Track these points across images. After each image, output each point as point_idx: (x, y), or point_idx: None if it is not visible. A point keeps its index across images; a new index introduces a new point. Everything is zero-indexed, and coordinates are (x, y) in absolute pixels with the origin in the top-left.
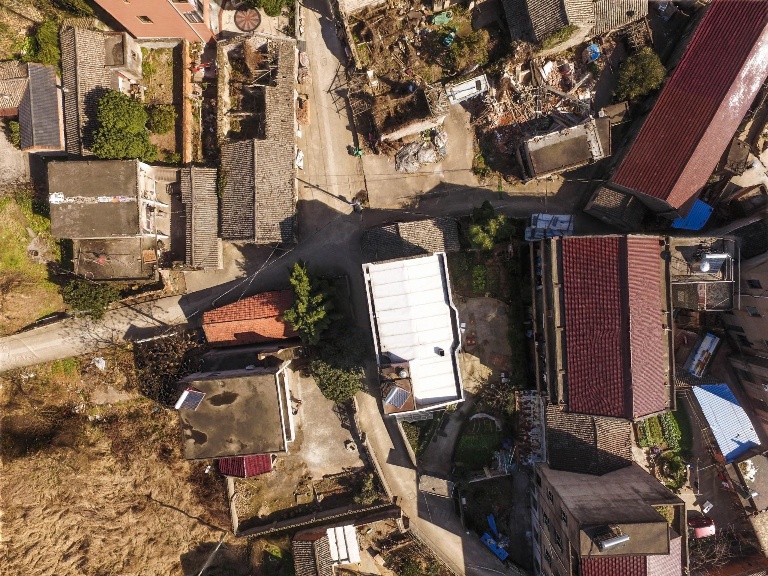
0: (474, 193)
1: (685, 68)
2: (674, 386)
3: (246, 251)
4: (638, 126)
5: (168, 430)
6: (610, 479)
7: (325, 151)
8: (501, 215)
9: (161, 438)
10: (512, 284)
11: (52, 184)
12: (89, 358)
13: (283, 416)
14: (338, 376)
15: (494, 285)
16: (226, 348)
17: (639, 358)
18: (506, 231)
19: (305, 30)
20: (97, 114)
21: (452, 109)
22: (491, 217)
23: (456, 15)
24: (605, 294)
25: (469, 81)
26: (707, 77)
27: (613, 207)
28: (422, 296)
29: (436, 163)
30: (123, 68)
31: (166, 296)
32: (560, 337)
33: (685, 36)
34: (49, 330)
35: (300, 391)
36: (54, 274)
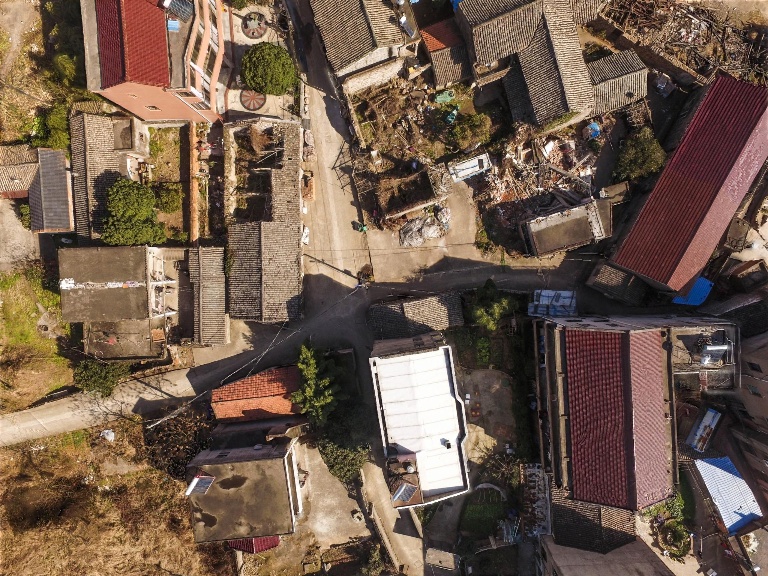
0: None
1: (684, 152)
2: (677, 460)
3: (253, 325)
4: (638, 205)
5: (177, 500)
6: (615, 558)
7: (330, 226)
8: (505, 299)
9: (170, 508)
10: (516, 359)
11: (63, 270)
12: (98, 430)
13: (291, 498)
14: (345, 455)
15: (498, 357)
16: (234, 424)
17: (642, 459)
18: (509, 307)
19: (310, 108)
20: (107, 203)
21: (455, 186)
22: (495, 300)
23: (458, 93)
24: (608, 387)
25: (472, 160)
26: (706, 162)
27: (615, 285)
28: (428, 389)
29: (440, 238)
30: (131, 151)
31: (174, 369)
32: (564, 425)
33: (684, 114)
34: (59, 403)
35: (307, 462)
36: (64, 348)
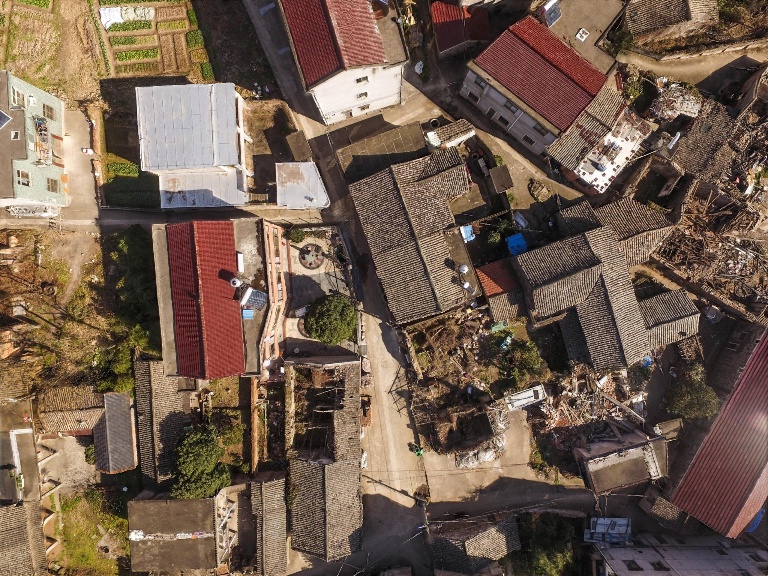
0: (532, 486)
1: (738, 400)
2: None
3: None
4: (692, 439)
5: None
6: None
7: (387, 448)
8: (568, 551)
9: None
10: None
11: (132, 522)
12: None
13: None
14: None
15: None
16: None
17: None
18: None
19: (366, 335)
20: (177, 463)
21: None
22: (557, 547)
23: (511, 320)
24: None
25: (527, 391)
26: (761, 415)
27: (670, 519)
28: None
29: (495, 460)
30: None
31: None
32: None
33: (733, 345)
34: None
35: None
36: (124, 568)
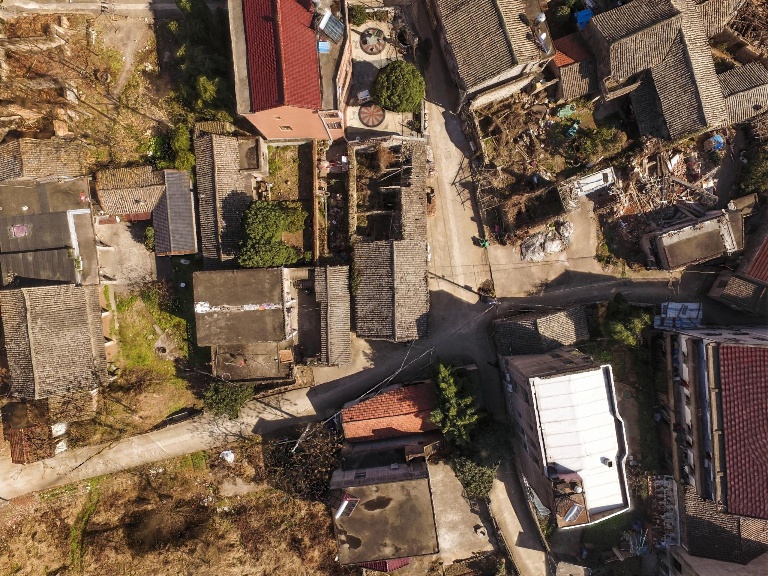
0: (598, 280)
1: None
2: None
3: (373, 342)
4: (766, 216)
5: (297, 519)
6: (757, 569)
7: (450, 242)
8: (646, 315)
9: (290, 527)
10: (643, 371)
11: (197, 294)
12: (217, 452)
13: None
14: (482, 473)
15: (620, 370)
16: (362, 443)
17: None
18: None
19: (429, 124)
20: (245, 226)
21: None
22: (633, 315)
23: (578, 107)
24: None
25: (596, 174)
26: None
27: (745, 297)
28: (588, 408)
29: (561, 252)
30: (257, 171)
31: (294, 388)
32: (717, 440)
33: None
34: (178, 426)
35: None
36: (182, 370)
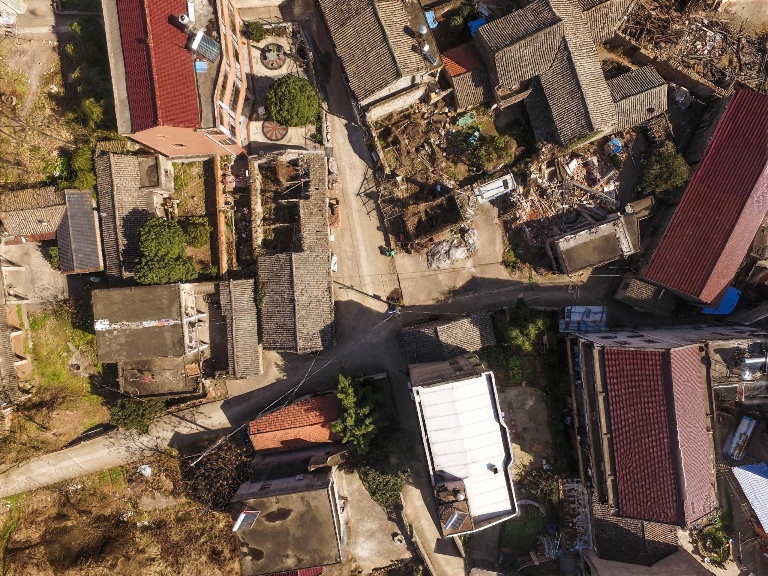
0: (506, 285)
1: (708, 165)
2: (714, 469)
3: (285, 353)
4: (664, 218)
5: (216, 532)
6: (660, 571)
7: (357, 252)
8: (539, 320)
9: (210, 540)
10: (549, 376)
11: (97, 311)
12: (135, 466)
13: (337, 527)
14: (387, 481)
15: (530, 374)
16: (272, 454)
17: (692, 477)
18: None
19: (332, 136)
20: (139, 244)
21: (480, 207)
22: (529, 320)
23: (479, 114)
24: (650, 405)
25: (496, 181)
26: (731, 175)
27: (645, 299)
28: (472, 415)
29: (467, 259)
30: (158, 188)
31: (208, 402)
32: (607, 443)
33: (703, 126)
34: (94, 442)
35: (345, 487)
36: (96, 386)
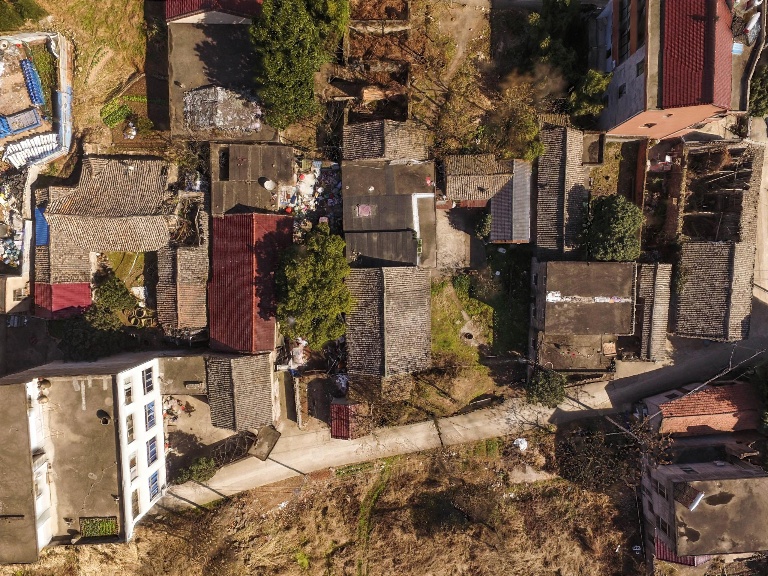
0: None
1: None
2: None
3: (675, 340)
4: None
5: (581, 510)
6: None
7: (761, 247)
8: None
9: (573, 517)
10: None
11: (550, 283)
12: (511, 439)
13: None
14: None
15: None
16: None
17: None
18: None
19: (751, 129)
20: (611, 219)
21: None
22: None
23: None
24: None
25: None
26: None
27: None
28: None
29: None
30: (598, 166)
31: (593, 381)
32: None
33: None
34: (477, 411)
35: None
36: (485, 357)
